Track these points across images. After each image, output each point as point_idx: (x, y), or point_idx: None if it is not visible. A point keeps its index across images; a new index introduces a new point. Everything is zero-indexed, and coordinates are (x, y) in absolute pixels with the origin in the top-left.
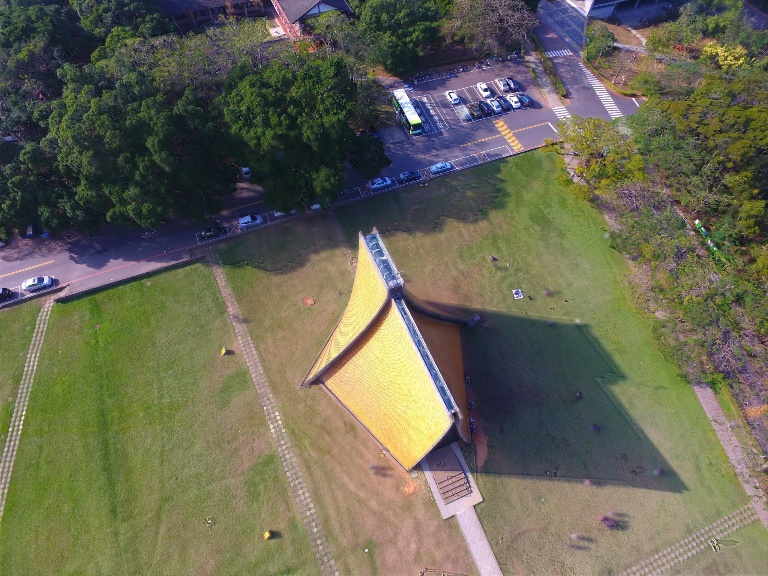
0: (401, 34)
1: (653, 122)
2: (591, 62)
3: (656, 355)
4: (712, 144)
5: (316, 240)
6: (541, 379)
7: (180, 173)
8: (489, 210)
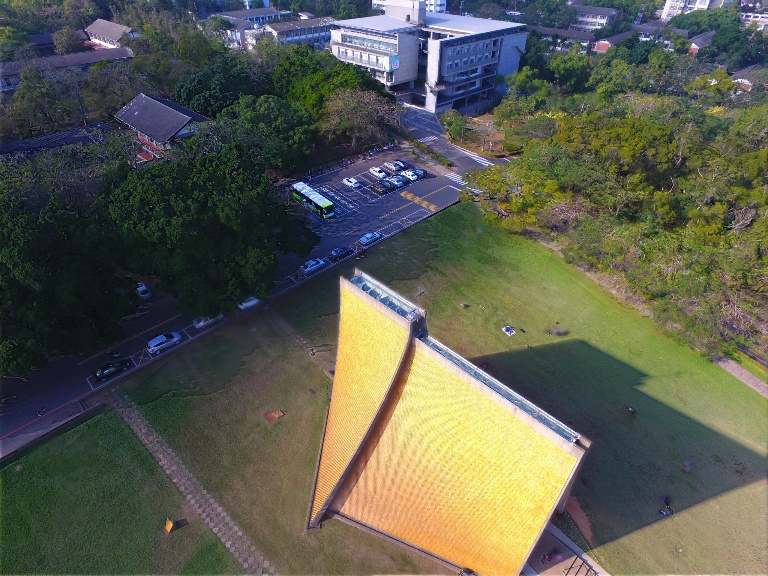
0: (283, 138)
1: (546, 153)
2: (457, 140)
3: (667, 346)
4: (604, 155)
5: (259, 341)
6: (585, 407)
7: (57, 289)
8: (436, 264)
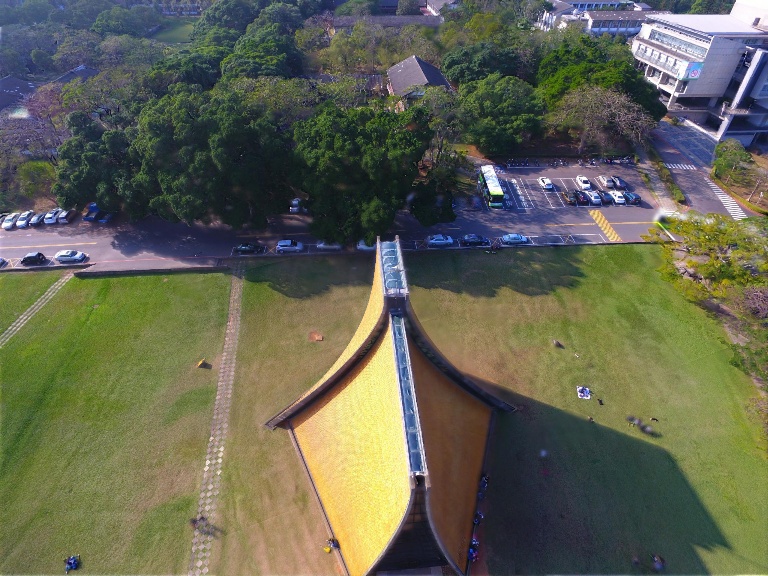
0: (502, 121)
1: None
2: (720, 178)
3: None
4: None
5: (350, 279)
6: (598, 516)
7: (231, 174)
8: (564, 292)
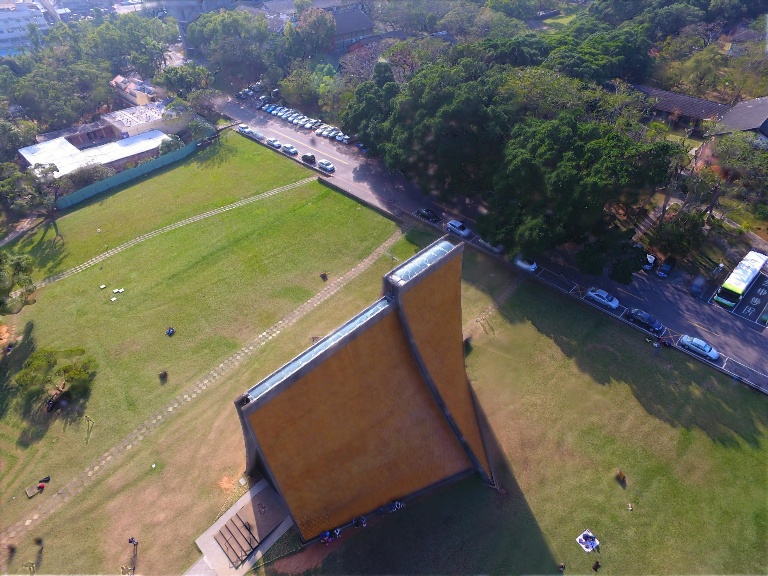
0: None
1: None
2: None
3: None
4: None
5: (481, 281)
6: None
7: (439, 144)
8: (701, 440)
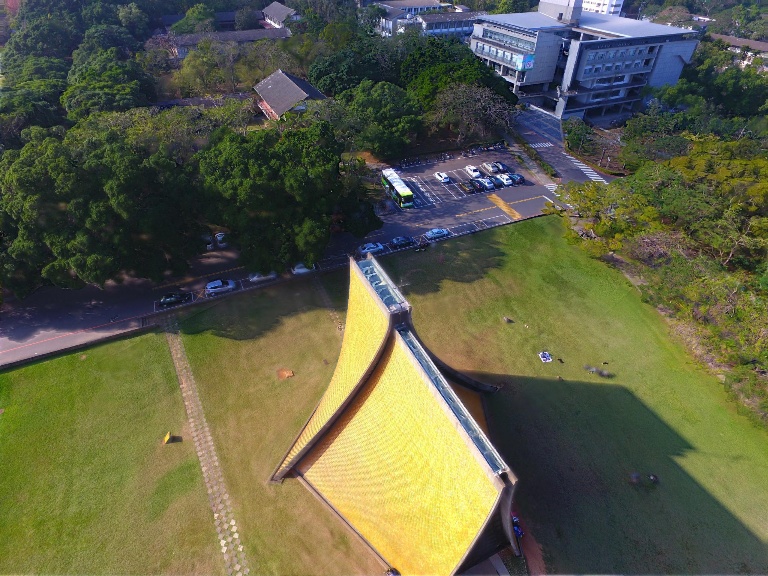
0: (387, 125)
1: (657, 177)
2: (573, 150)
3: (736, 423)
4: (728, 188)
5: (298, 306)
6: (598, 459)
7: (140, 222)
8: (495, 272)
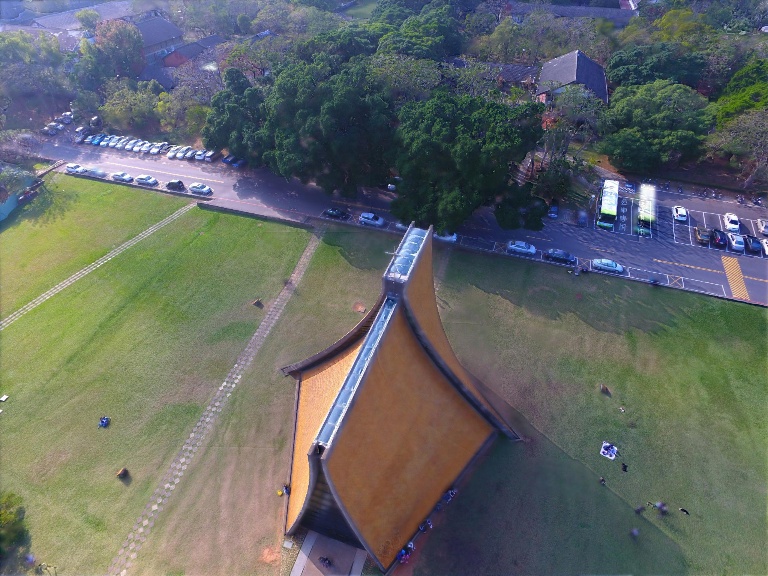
0: (650, 134)
1: None
2: None
3: None
4: None
5: None
6: None
7: (332, 141)
8: (642, 337)
